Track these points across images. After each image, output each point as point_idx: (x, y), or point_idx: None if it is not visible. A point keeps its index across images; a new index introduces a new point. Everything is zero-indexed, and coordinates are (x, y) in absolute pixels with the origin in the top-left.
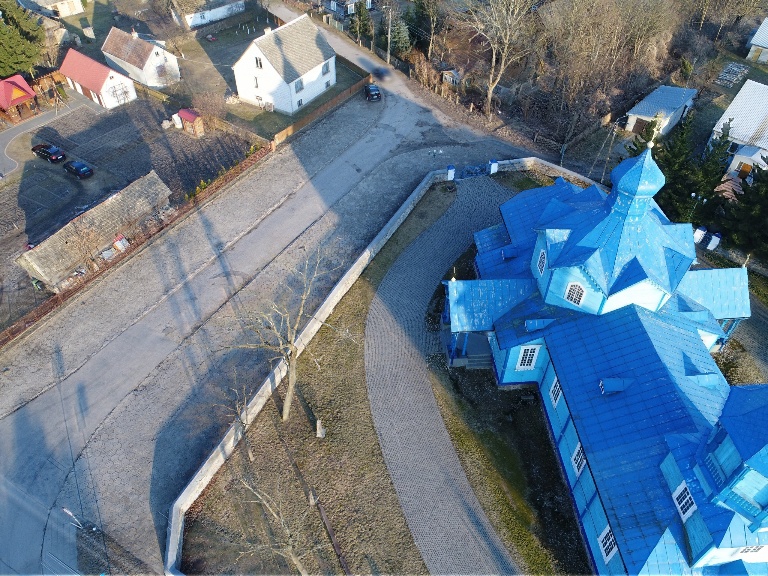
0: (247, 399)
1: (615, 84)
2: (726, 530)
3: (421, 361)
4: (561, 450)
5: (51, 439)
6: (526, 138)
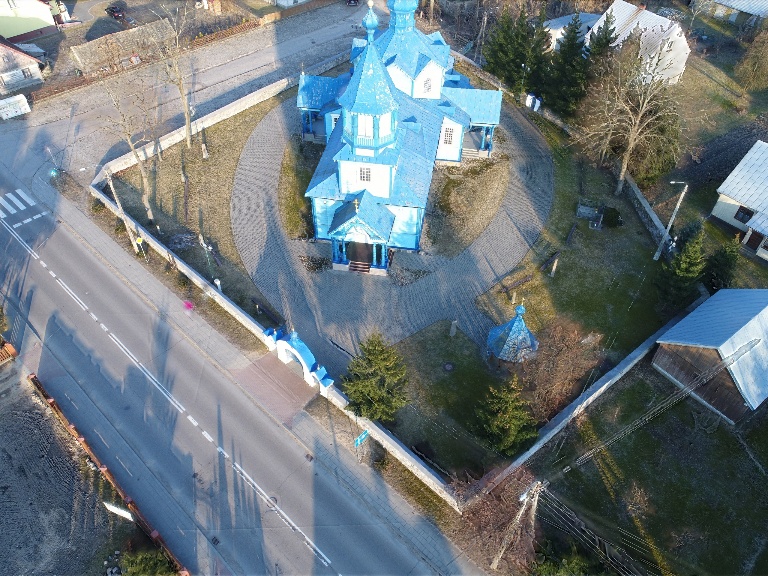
0: None
1: (540, 7)
2: (339, 151)
3: (287, 136)
4: None
5: (57, 137)
6: (450, 37)
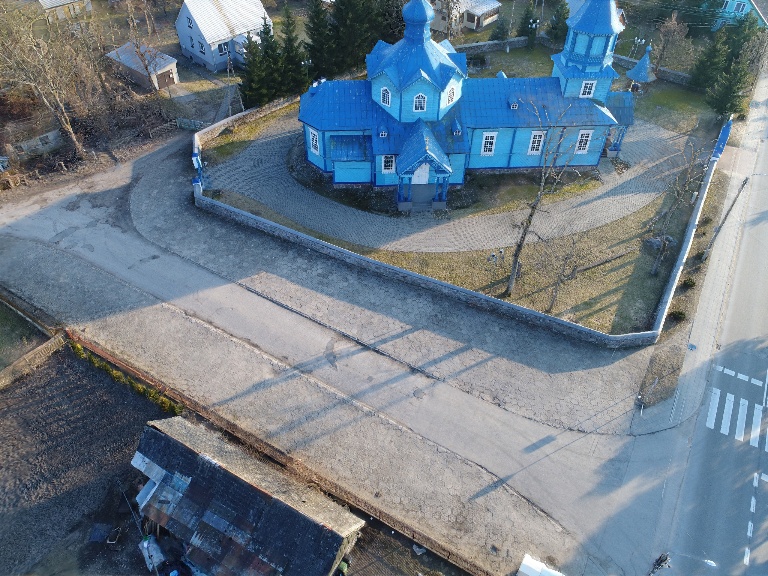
0: (496, 318)
1: (93, 72)
2: None
3: (442, 222)
4: (514, 164)
5: (571, 461)
6: (143, 142)
